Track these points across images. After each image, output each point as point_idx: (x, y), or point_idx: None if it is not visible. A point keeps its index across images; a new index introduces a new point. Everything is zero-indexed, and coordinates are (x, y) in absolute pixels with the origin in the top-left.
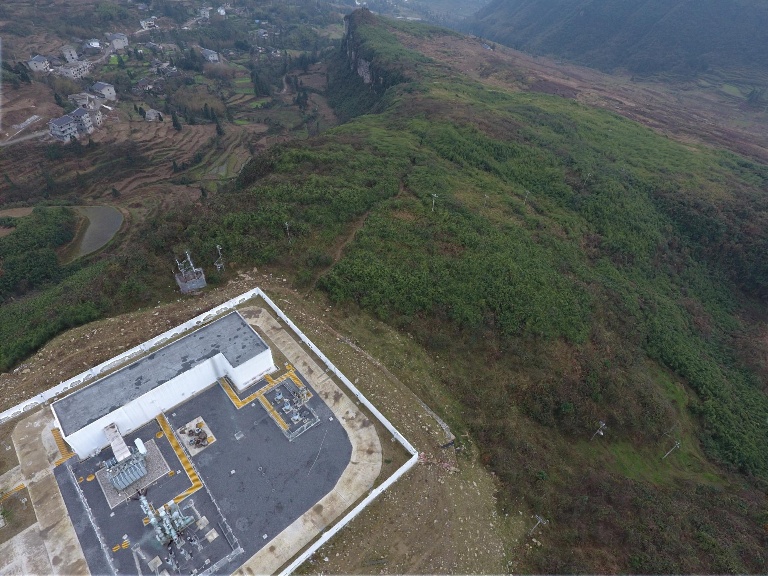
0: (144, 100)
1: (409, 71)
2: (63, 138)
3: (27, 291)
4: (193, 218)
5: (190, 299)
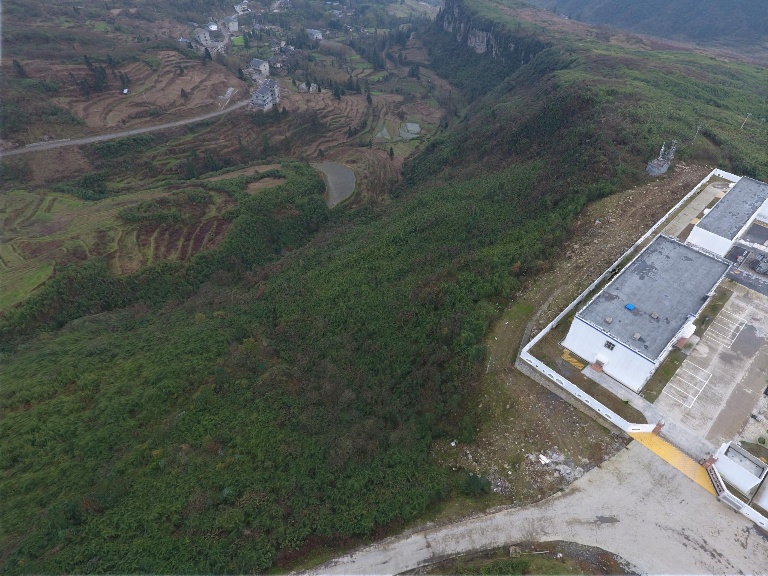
0: (289, 75)
1: (543, 37)
2: (263, 107)
3: (320, 228)
4: (619, 127)
5: (666, 179)
